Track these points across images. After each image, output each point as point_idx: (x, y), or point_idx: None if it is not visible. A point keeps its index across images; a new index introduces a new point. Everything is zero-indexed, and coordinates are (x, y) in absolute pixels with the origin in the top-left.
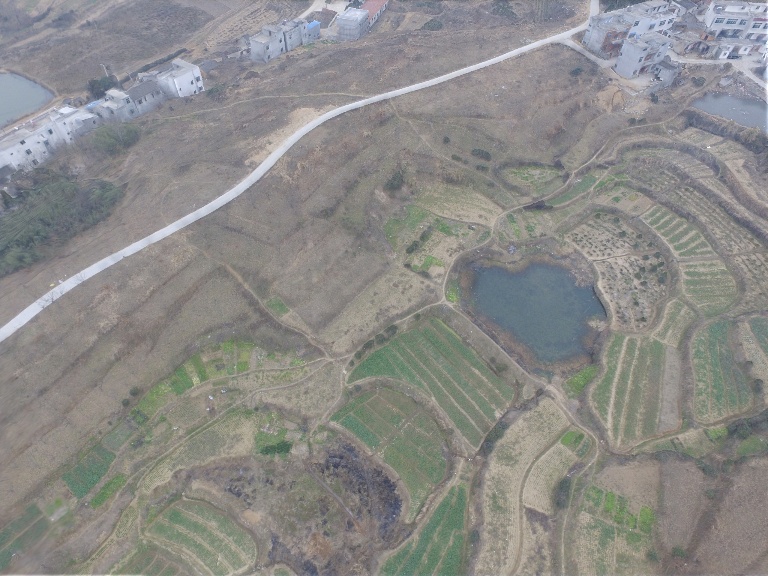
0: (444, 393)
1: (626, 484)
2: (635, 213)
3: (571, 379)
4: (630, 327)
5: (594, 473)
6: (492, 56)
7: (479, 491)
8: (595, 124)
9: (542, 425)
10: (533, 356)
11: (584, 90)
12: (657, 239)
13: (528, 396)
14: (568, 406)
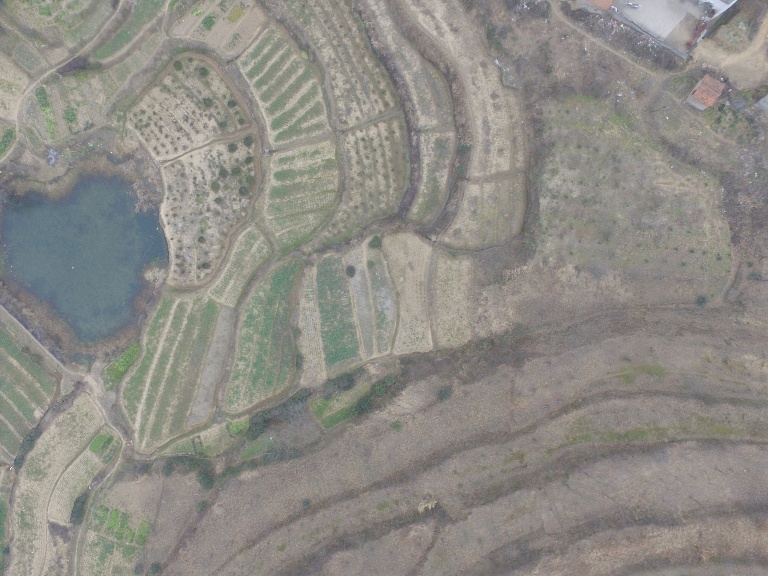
0: None
1: (130, 500)
2: (232, 52)
3: (112, 365)
4: (189, 279)
5: (107, 488)
6: None
7: (10, 509)
8: None
9: (73, 430)
10: (73, 337)
11: None
12: (253, 108)
13: (65, 392)
14: (103, 402)
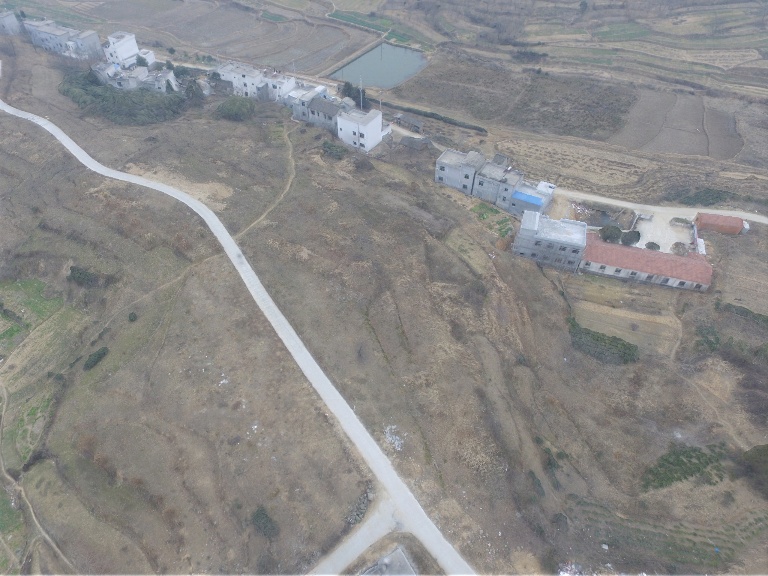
0: None
1: None
2: None
3: None
4: None
5: None
6: (332, 372)
7: None
8: (129, 555)
9: None
10: None
11: (226, 545)
12: None
13: None
14: None
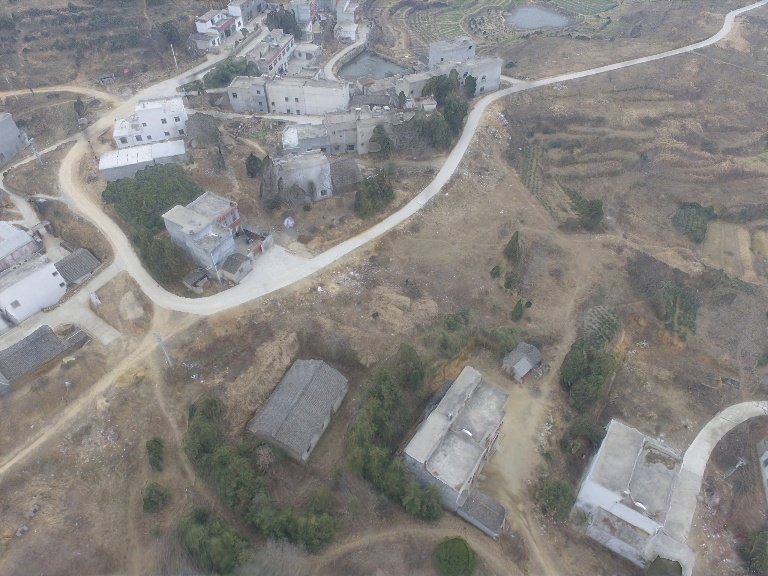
0: (575, 3)
1: None
2: None
3: (524, 2)
4: None
5: None
6: None
7: None
8: None
9: None
10: (539, 7)
11: None
12: None
13: None
14: None
